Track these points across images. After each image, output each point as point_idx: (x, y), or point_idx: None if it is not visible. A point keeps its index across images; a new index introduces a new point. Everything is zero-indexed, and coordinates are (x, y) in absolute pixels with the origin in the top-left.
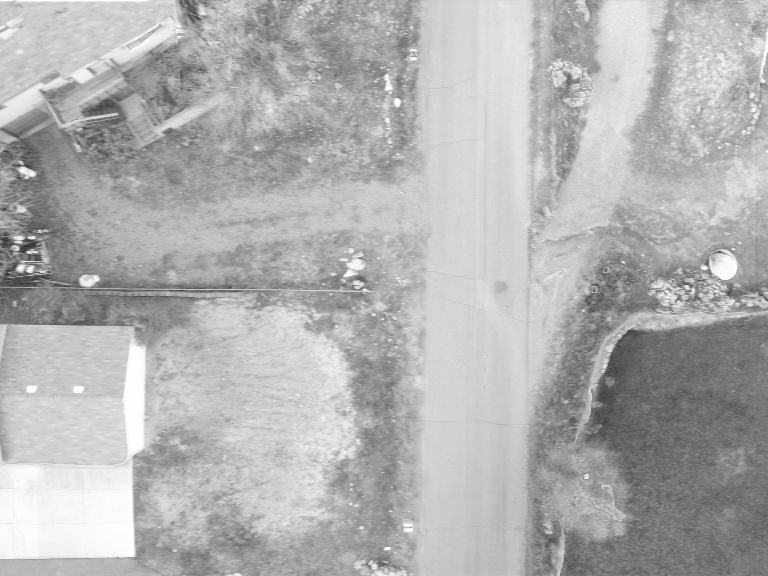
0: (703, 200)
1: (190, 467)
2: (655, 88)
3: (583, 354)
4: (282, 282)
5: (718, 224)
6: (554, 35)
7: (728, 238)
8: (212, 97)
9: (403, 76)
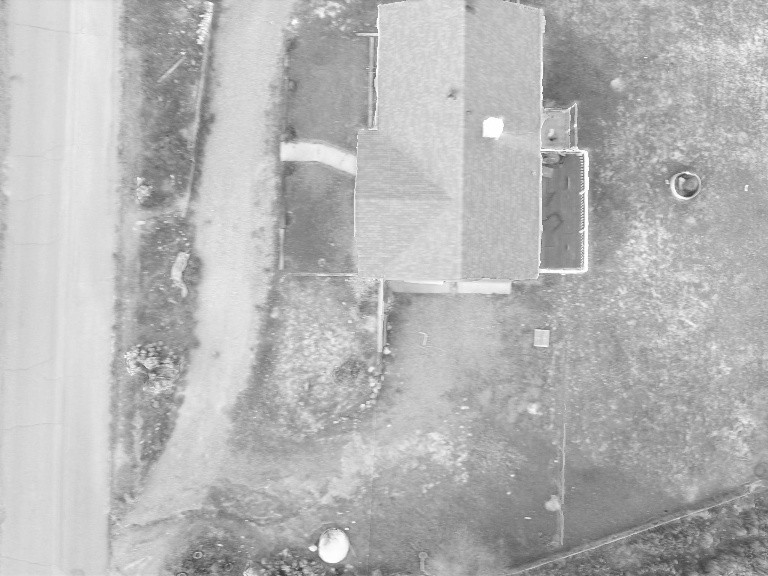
0: (314, 478)
1: None
2: (257, 366)
3: None
4: None
5: (329, 503)
6: (140, 316)
7: (340, 517)
8: None
9: None
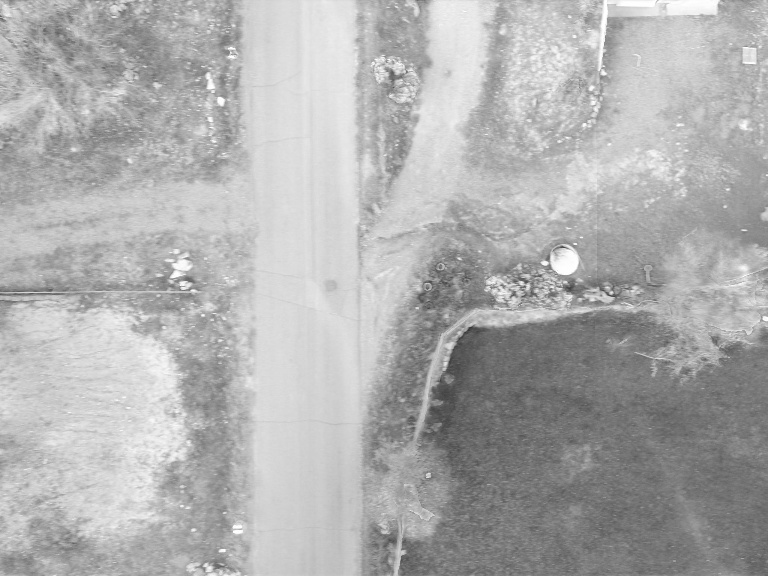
0: (543, 195)
1: (7, 471)
2: (488, 82)
3: (420, 352)
4: (106, 284)
5: (558, 219)
6: (380, 31)
7: (569, 233)
8: (24, 99)
9: (226, 74)
